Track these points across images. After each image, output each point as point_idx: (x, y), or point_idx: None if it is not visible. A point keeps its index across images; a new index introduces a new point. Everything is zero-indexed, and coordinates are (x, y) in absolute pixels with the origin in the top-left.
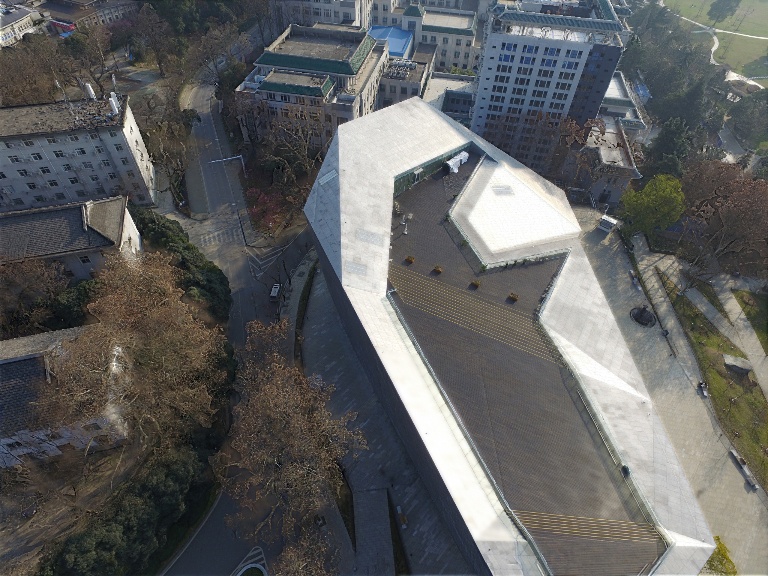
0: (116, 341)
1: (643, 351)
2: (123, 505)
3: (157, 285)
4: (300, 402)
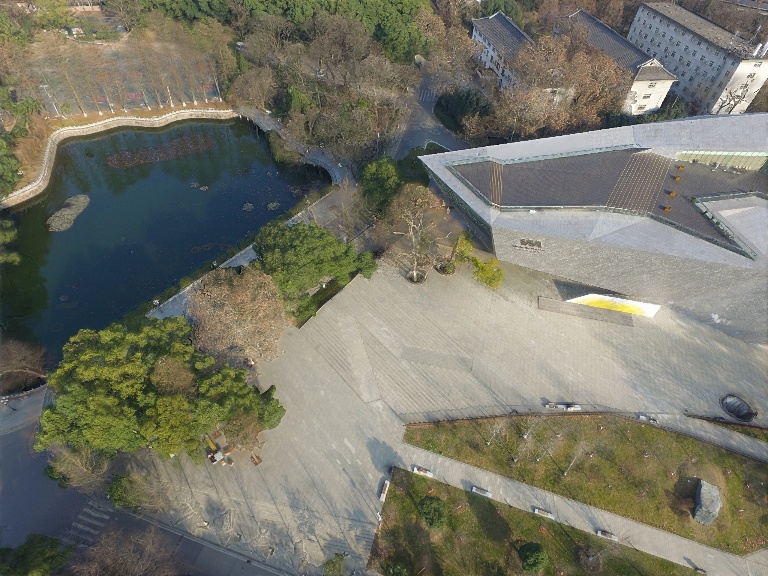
0: (558, 50)
1: (681, 385)
2: (493, 102)
3: (601, 72)
4: (544, 104)
